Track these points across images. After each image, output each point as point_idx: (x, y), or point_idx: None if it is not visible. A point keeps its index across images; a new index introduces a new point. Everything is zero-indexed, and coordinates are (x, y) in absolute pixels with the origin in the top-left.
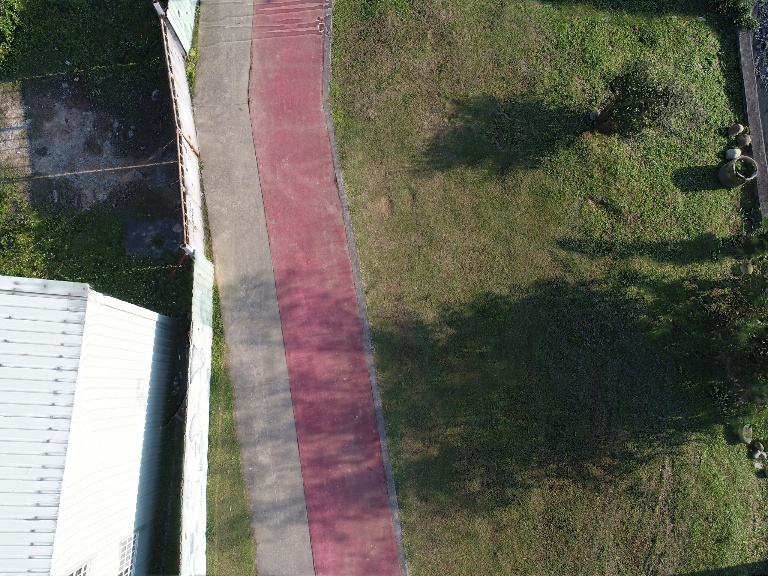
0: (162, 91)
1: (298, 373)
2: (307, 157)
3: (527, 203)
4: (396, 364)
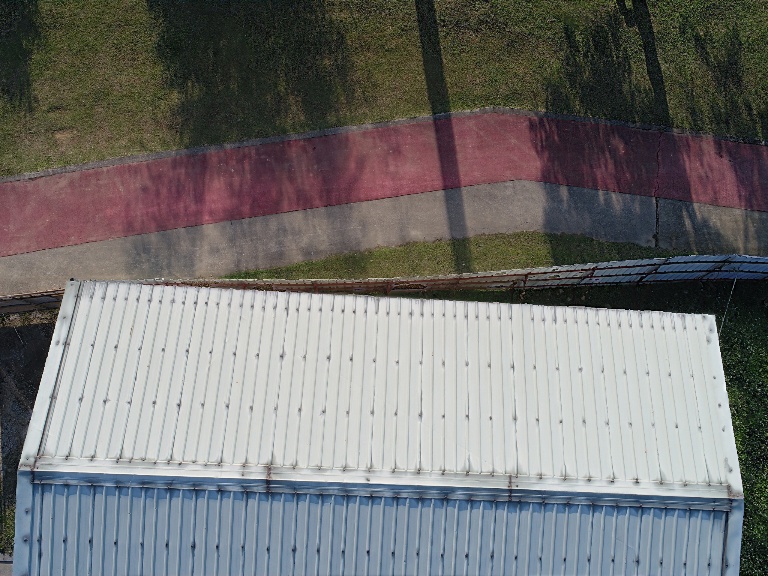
0: None
1: (225, 212)
2: (4, 207)
3: (72, 7)
4: (221, 126)
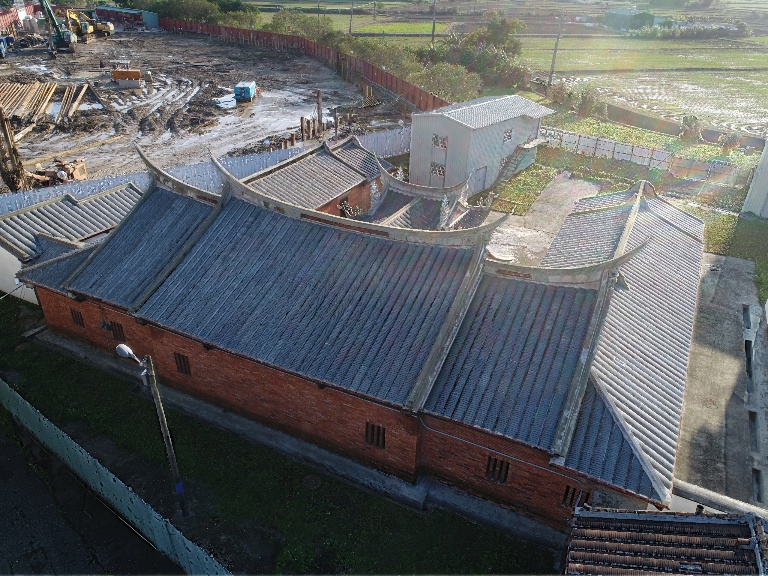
0: (677, 179)
1: None
2: None
3: None
4: None
